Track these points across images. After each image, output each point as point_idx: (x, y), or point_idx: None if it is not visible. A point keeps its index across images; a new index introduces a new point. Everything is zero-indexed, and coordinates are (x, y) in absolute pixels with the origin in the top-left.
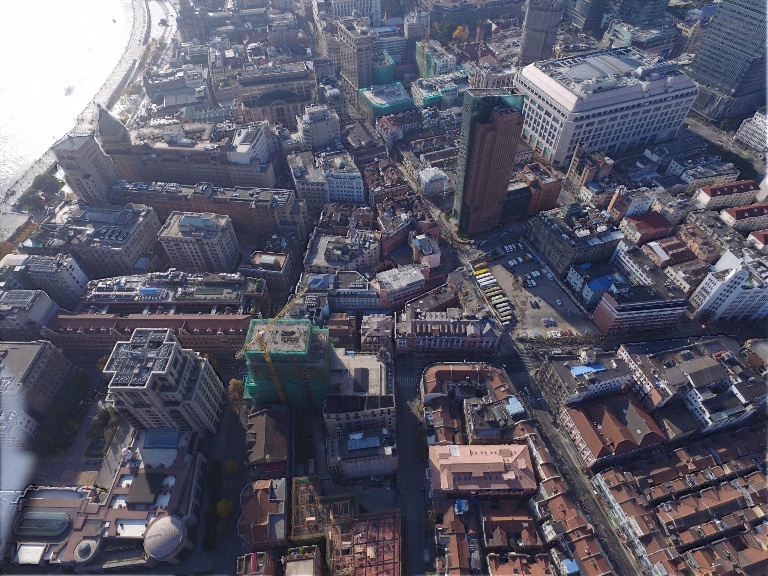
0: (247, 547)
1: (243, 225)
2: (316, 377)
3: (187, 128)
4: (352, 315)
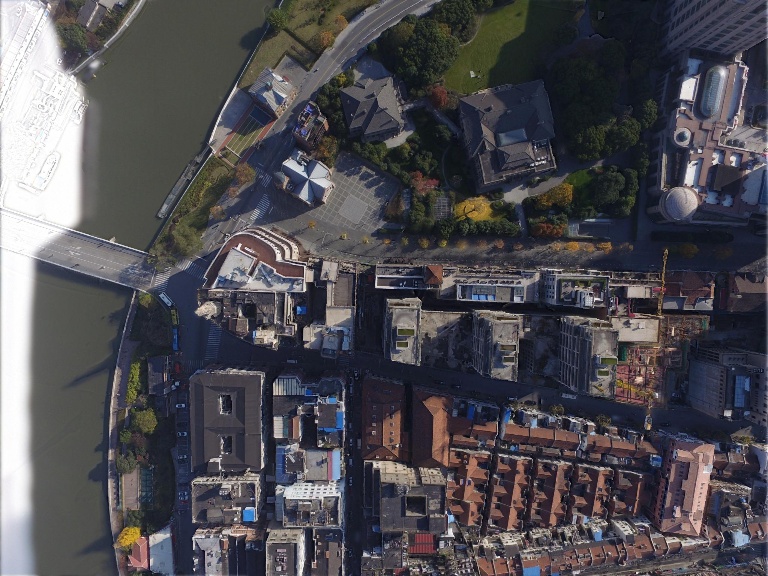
0: (649, 269)
1: None
2: None
3: None
4: None
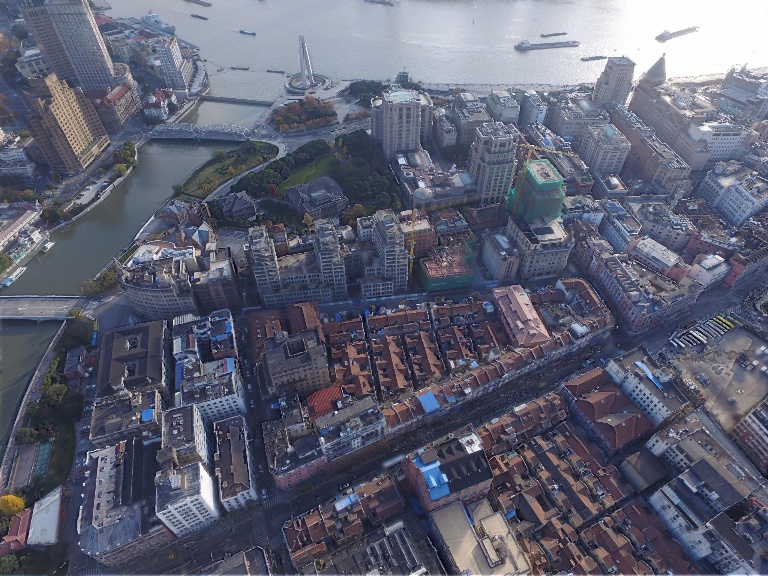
0: None
1: (640, 169)
2: (531, 207)
3: (698, 102)
4: (603, 239)
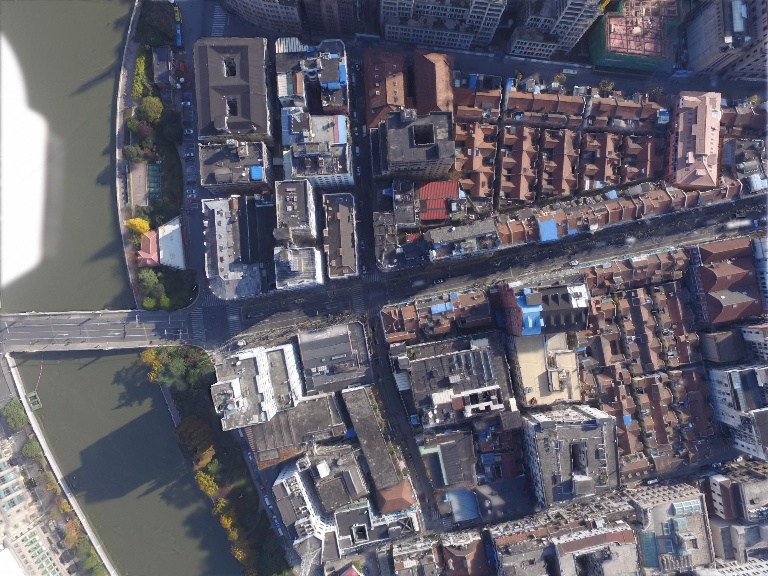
0: None
1: None
2: None
3: None
4: None
